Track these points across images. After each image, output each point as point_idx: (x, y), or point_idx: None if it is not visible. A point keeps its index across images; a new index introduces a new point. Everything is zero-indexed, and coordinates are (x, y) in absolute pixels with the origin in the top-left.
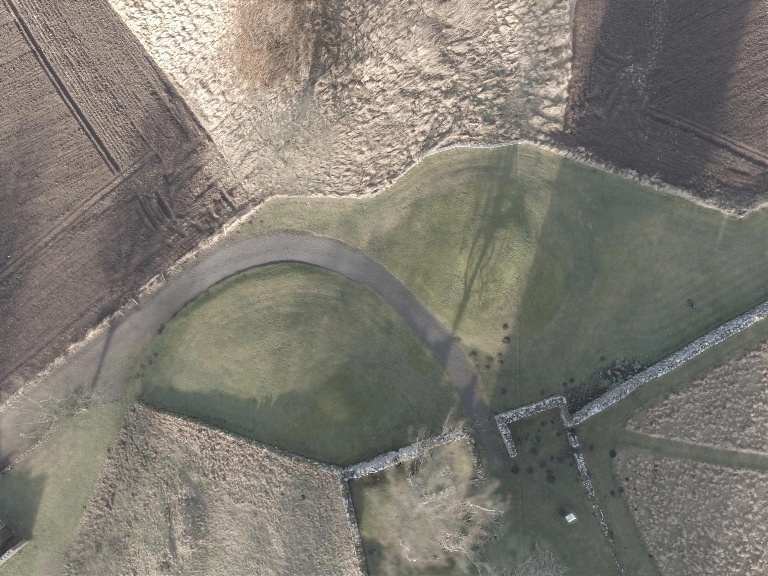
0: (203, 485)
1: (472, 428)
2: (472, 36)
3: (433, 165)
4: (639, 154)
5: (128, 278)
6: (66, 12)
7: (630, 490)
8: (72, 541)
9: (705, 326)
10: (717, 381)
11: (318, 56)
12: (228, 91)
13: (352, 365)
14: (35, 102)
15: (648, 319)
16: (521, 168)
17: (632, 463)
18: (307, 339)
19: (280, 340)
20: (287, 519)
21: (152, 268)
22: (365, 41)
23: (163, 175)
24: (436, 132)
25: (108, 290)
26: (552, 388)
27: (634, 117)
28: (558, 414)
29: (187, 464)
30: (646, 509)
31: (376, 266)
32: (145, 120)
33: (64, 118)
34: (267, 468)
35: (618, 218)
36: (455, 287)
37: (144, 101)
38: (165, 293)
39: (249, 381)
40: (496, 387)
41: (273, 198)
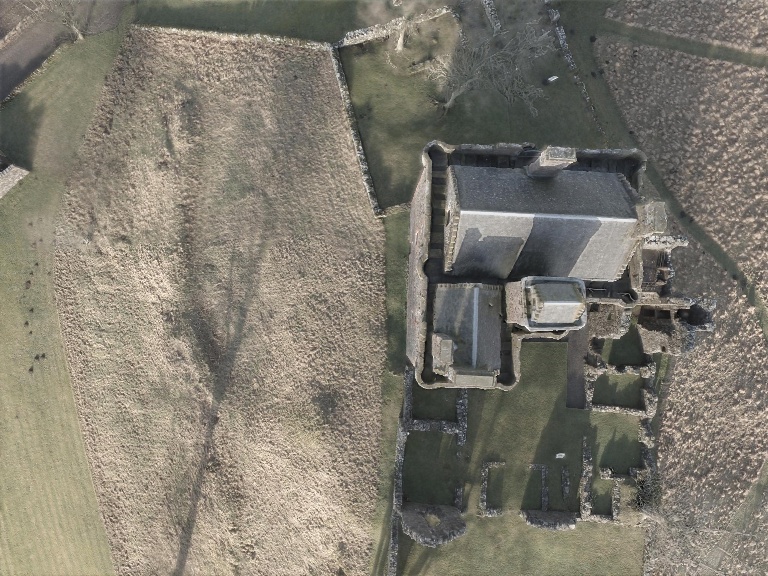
0: (198, 89)
1: (457, 7)
2: None
3: None
4: None
5: None
6: None
7: (610, 72)
8: (72, 170)
9: None
10: None
11: None
12: None
13: None
14: None
15: None
16: None
17: (612, 48)
18: None
19: None
20: (280, 98)
21: None
22: None
23: None
24: None
25: None
26: None
27: None
28: None
29: (182, 76)
30: (626, 90)
31: None
32: None
33: None
34: (260, 57)
35: None
36: None
37: None
38: None
39: None
40: None
41: None
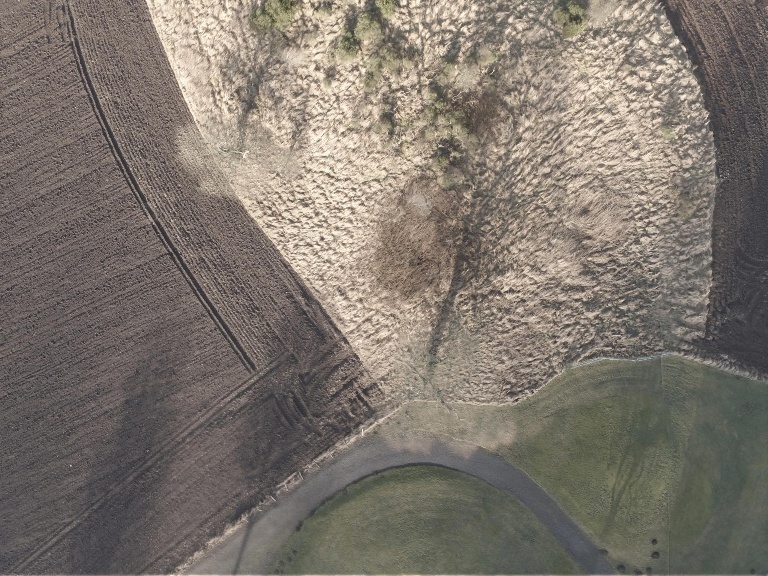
0: None
1: None
2: (612, 247)
3: (575, 376)
4: None
5: (265, 475)
6: (203, 217)
7: None
8: None
9: None
10: None
11: (459, 270)
12: (366, 299)
13: (498, 575)
14: (172, 302)
15: None
16: (665, 379)
17: None
18: (452, 548)
19: (423, 547)
20: None
21: (289, 465)
22: (505, 253)
23: (299, 374)
24: (578, 344)
25: (245, 486)
26: None
27: None
28: None
29: None
30: None
31: (517, 473)
32: (281, 322)
33: (201, 318)
34: None
35: (763, 426)
36: (602, 500)
37: (280, 304)
38: (302, 490)
39: None
40: None
41: (411, 402)
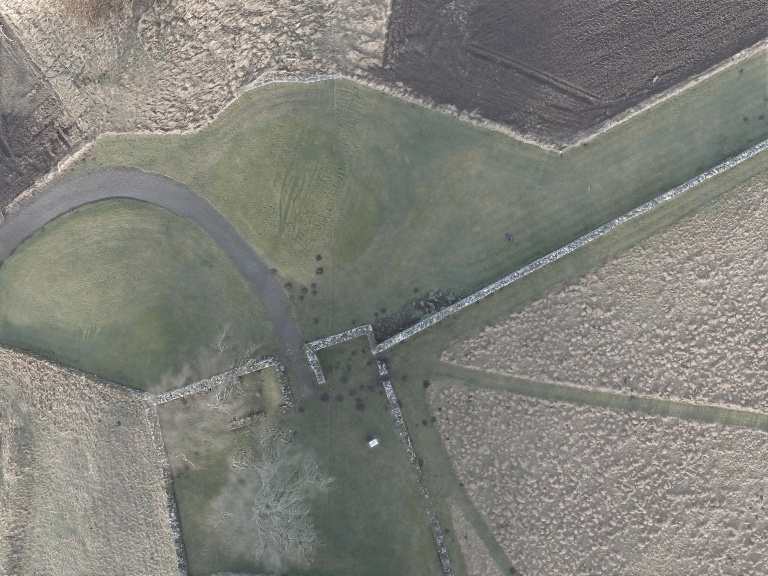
0: (31, 415)
1: (283, 356)
2: None
3: (252, 100)
4: (459, 90)
5: None
6: None
7: (442, 420)
8: None
9: (522, 260)
10: (535, 314)
11: None
12: (58, 30)
13: (173, 296)
14: None
15: (465, 252)
16: (338, 102)
17: (445, 393)
18: (130, 271)
19: (106, 273)
20: (103, 445)
21: None
22: None
23: (2, 115)
24: (255, 67)
25: None
26: (363, 318)
27: (455, 53)
28: (369, 343)
29: (19, 395)
30: (459, 439)
31: (200, 201)
32: None
33: None
34: (87, 396)
35: (436, 152)
36: (271, 219)
37: None
38: (4, 230)
39: (76, 313)
40: (309, 317)
41: (104, 135)
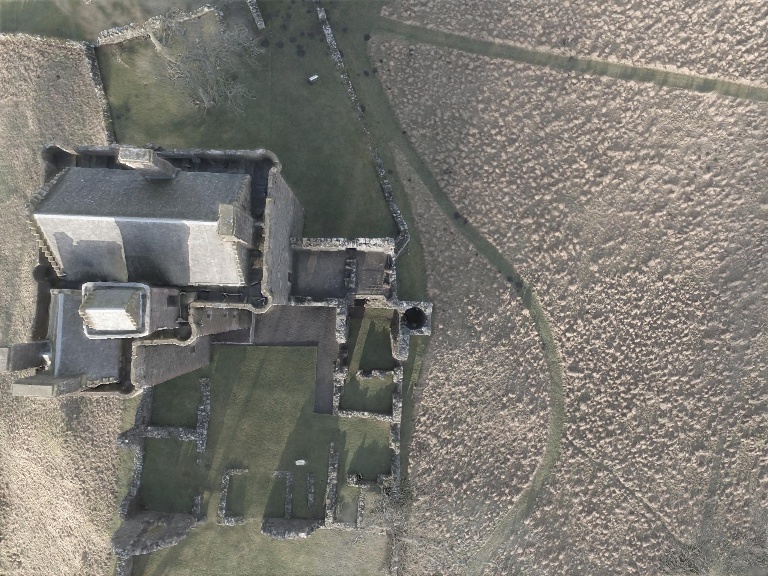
0: None
1: (222, 5)
2: None
3: None
4: None
5: None
6: None
7: (384, 71)
8: None
9: None
10: None
11: None
12: None
13: None
14: None
15: None
16: None
17: (386, 46)
18: None
19: None
20: (42, 99)
21: None
22: None
23: None
24: None
25: None
26: None
27: None
28: None
29: None
30: (400, 90)
31: None
32: None
33: None
34: (25, 56)
35: None
36: None
37: None
38: None
39: None
40: None
41: None
